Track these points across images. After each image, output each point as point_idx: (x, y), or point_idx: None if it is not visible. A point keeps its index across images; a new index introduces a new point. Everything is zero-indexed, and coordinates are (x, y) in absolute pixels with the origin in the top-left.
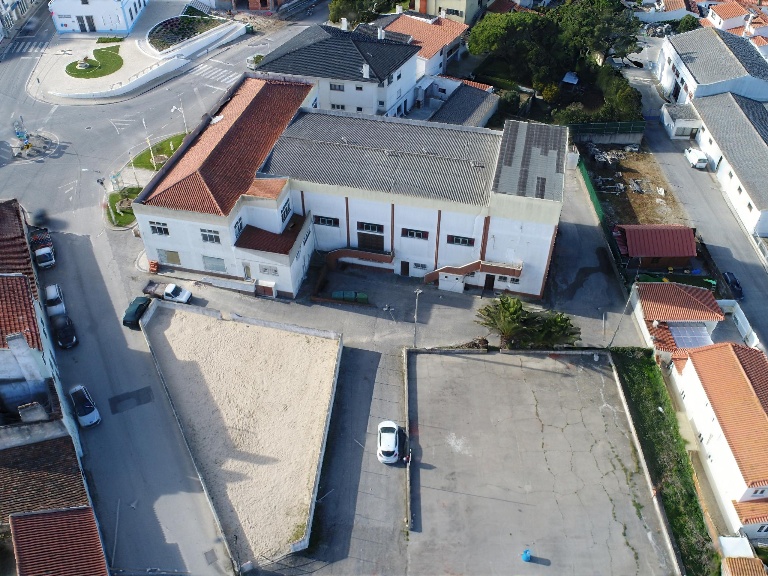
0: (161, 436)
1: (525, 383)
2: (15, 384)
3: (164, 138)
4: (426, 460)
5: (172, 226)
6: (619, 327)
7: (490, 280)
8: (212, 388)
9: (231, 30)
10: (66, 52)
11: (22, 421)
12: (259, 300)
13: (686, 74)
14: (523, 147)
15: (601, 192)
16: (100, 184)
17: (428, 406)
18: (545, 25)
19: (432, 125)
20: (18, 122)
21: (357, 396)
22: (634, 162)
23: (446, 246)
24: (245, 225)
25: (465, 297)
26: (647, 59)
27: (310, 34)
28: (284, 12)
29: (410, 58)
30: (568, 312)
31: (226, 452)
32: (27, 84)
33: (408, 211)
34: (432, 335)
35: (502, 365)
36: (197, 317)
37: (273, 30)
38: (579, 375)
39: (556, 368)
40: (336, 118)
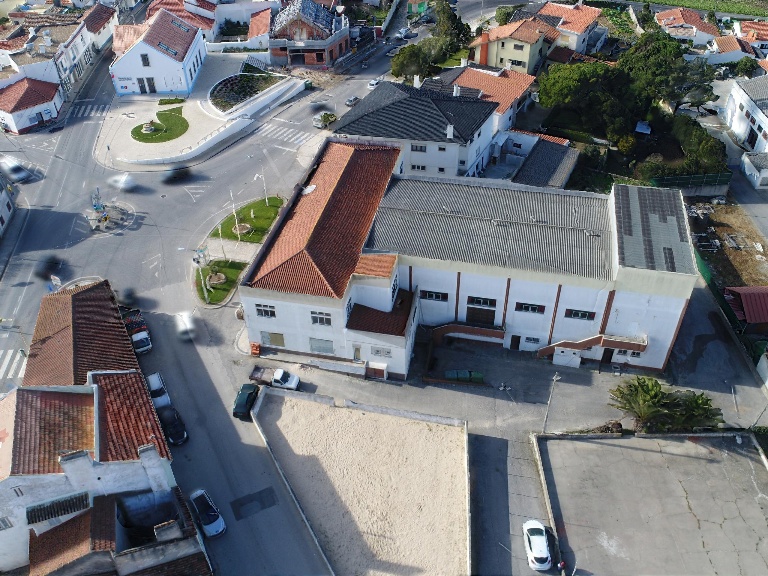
0: (293, 545)
1: (669, 471)
2: (141, 496)
3: (242, 205)
4: (581, 565)
5: (280, 309)
6: (751, 402)
7: (608, 353)
8: (338, 487)
9: (290, 87)
10: (129, 115)
11: (156, 540)
12: (370, 383)
13: (765, 121)
14: (639, 214)
15: (697, 250)
16: (196, 263)
17: (570, 501)
18: (616, 75)
19: (533, 190)
20: (91, 192)
21: (492, 491)
22: (724, 215)
23: (563, 320)
24: (353, 304)
25: (582, 372)
26: (711, 103)
27: (384, 93)
28: (339, 66)
29: (490, 116)
30: (694, 386)
31: (365, 562)
32: (94, 150)
33: (525, 285)
34: (557, 417)
35: (640, 451)
36: (308, 405)
37: (331, 85)
38: (725, 461)
39: (698, 453)
40: (431, 184)
